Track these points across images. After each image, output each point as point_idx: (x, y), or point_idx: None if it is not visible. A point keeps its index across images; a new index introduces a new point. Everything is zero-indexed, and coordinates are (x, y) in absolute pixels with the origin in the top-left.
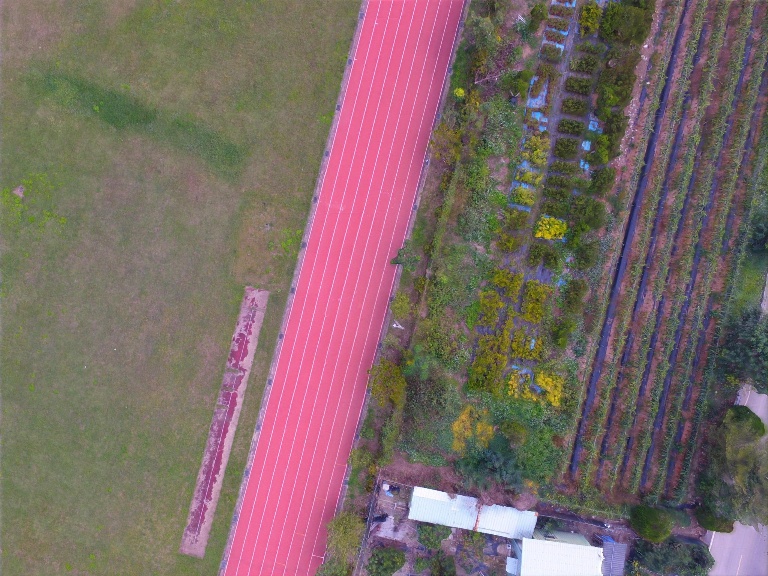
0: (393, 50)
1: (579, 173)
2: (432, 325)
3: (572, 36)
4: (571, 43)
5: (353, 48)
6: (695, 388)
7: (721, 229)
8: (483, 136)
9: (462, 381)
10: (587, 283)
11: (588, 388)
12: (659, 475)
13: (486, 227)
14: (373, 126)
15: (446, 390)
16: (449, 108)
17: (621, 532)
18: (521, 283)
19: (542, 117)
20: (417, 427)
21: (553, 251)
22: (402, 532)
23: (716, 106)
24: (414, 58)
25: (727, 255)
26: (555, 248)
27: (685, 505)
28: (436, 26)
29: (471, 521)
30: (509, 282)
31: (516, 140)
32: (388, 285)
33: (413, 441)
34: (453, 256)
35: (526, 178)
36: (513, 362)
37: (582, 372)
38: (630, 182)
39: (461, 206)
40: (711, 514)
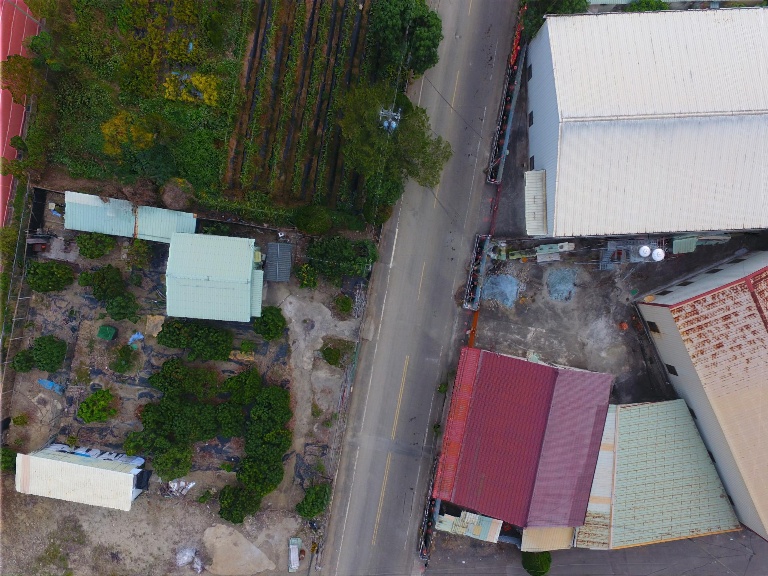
0: None
1: None
2: (82, 30)
3: None
4: None
5: None
6: None
7: None
8: None
9: (119, 89)
10: None
11: (253, 93)
12: (320, 171)
13: None
14: None
15: (90, 89)
16: None
17: (298, 242)
18: None
19: None
20: (64, 130)
21: None
22: (74, 253)
23: None
24: None
25: None
26: None
27: (360, 210)
28: None
29: (129, 227)
30: None
31: None
32: None
33: (63, 146)
34: None
35: None
36: (172, 68)
37: (244, 75)
38: None
39: None
40: (367, 202)
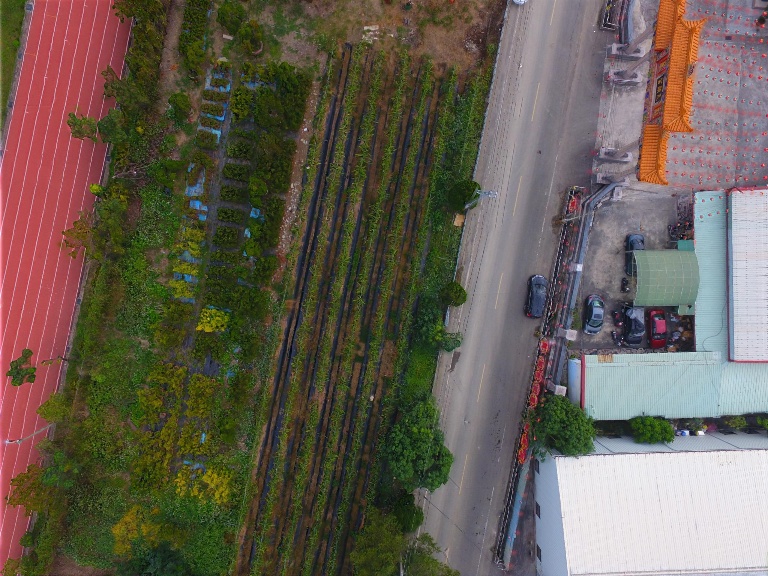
0: (46, 139)
1: (242, 262)
2: (95, 424)
3: (229, 121)
4: (228, 128)
5: (3, 138)
6: (372, 475)
7: (380, 317)
8: (136, 228)
9: None
10: (256, 374)
11: (264, 480)
12: (330, 568)
13: (147, 321)
14: (29, 219)
15: (102, 494)
16: (96, 201)
17: None
18: (179, 379)
19: (202, 205)
20: (75, 533)
21: (215, 344)
22: None
23: (378, 189)
24: (69, 147)
25: (398, 340)
26: (220, 340)
27: None
28: (91, 113)
29: None
30: (168, 378)
31: (174, 230)
32: (53, 383)
33: (73, 547)
34: (113, 352)
35: (178, 272)
36: (184, 457)
37: None
38: (295, 269)
39: (119, 300)
40: None
